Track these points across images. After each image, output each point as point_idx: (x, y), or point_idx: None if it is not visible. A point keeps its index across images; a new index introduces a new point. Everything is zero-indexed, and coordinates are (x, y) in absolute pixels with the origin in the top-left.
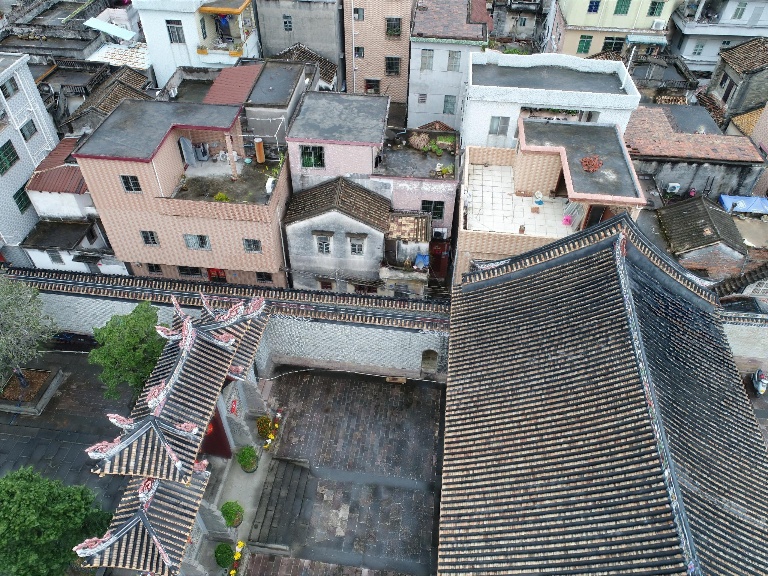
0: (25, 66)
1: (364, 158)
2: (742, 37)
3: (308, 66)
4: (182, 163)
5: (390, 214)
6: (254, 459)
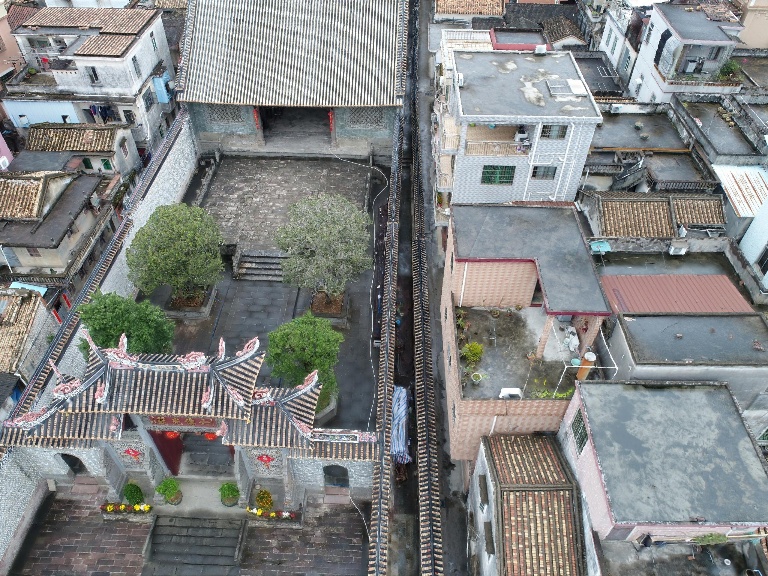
0: (592, 126)
1: (600, 506)
2: None
3: None
4: (534, 298)
5: None
6: (235, 500)
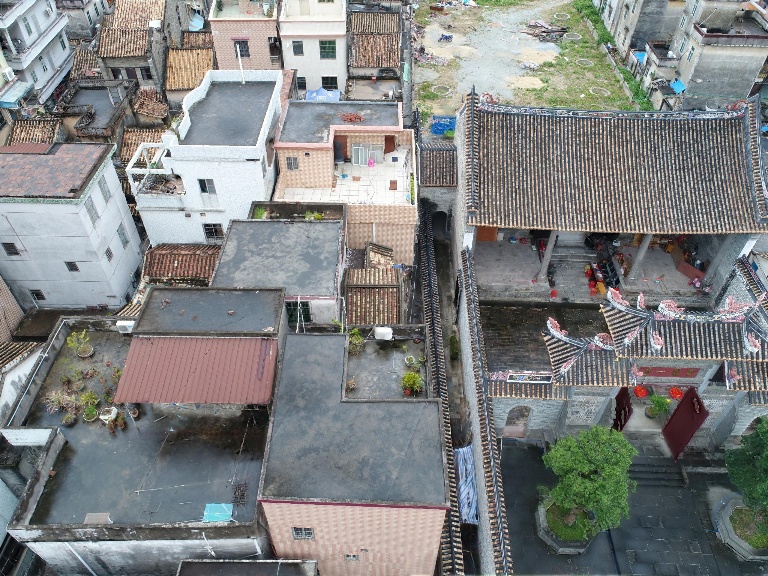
0: None
1: None
2: (47, 45)
3: (59, 333)
4: None
5: (368, 267)
6: None
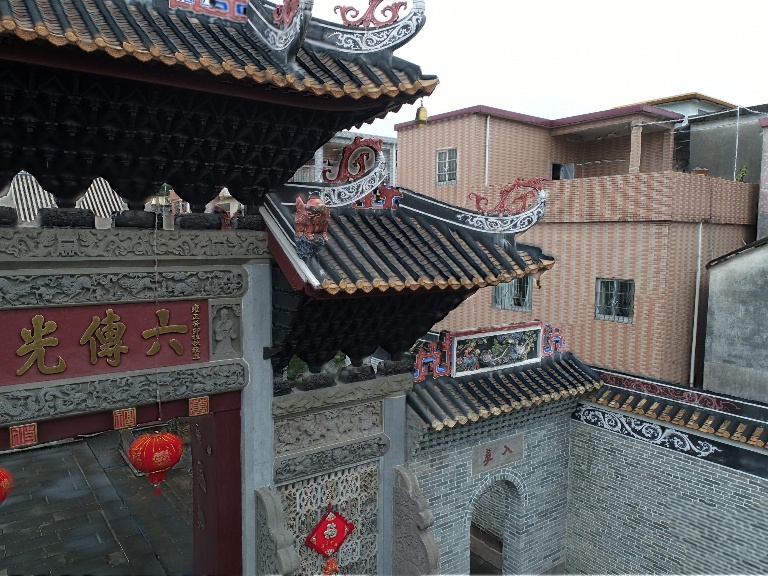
0: None
1: None
2: None
3: None
4: None
5: None
6: None
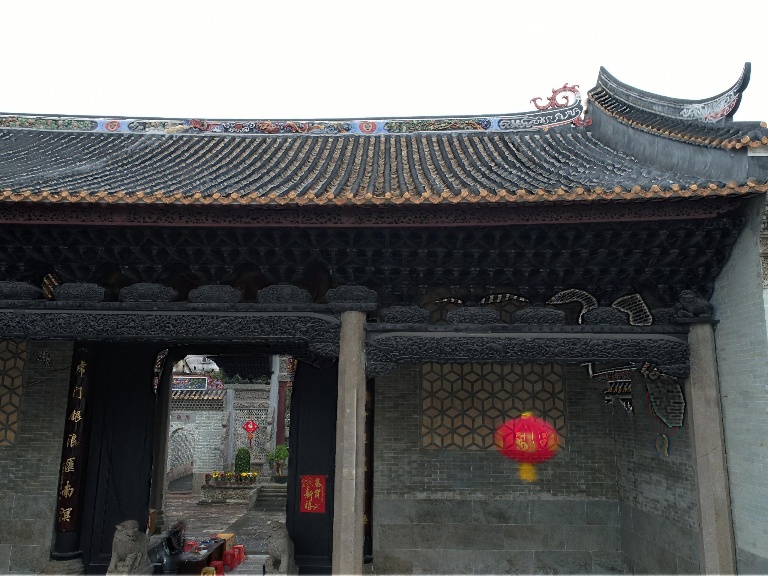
0: None
1: None
2: None
3: None
4: None
5: None
6: None
